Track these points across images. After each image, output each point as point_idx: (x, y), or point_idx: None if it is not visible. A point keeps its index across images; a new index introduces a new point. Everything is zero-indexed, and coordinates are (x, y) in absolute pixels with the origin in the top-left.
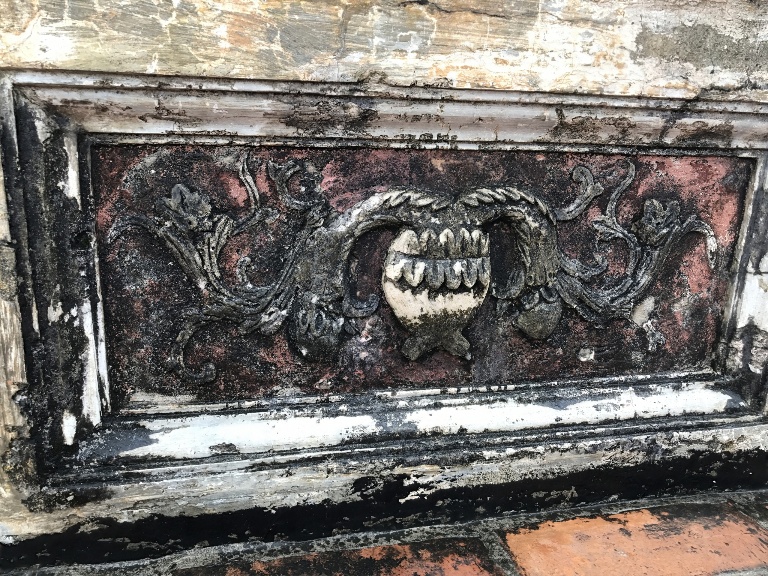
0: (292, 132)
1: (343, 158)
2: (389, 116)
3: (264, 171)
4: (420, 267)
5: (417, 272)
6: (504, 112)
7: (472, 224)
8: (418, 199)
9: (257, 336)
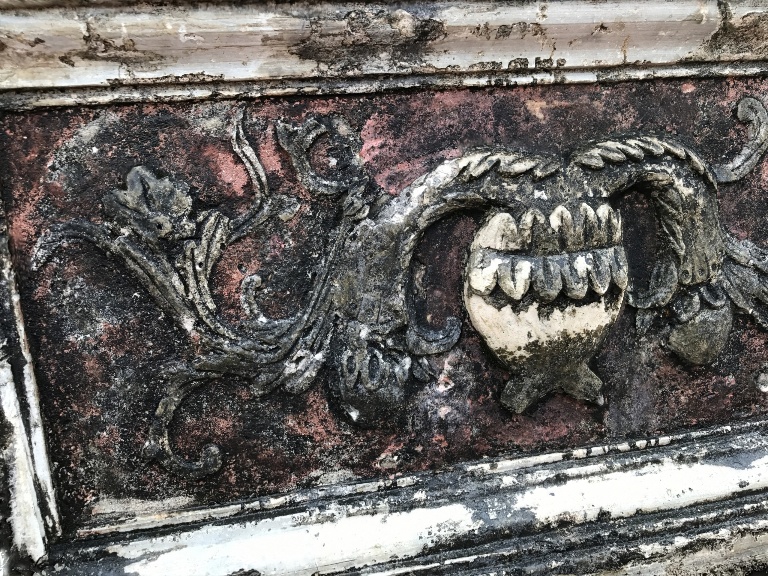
0: (310, 69)
1: (391, 109)
2: (461, 30)
3: (271, 138)
4: (523, 269)
5: (519, 277)
6: (639, 12)
7: (596, 196)
8: (512, 163)
9: (280, 396)
